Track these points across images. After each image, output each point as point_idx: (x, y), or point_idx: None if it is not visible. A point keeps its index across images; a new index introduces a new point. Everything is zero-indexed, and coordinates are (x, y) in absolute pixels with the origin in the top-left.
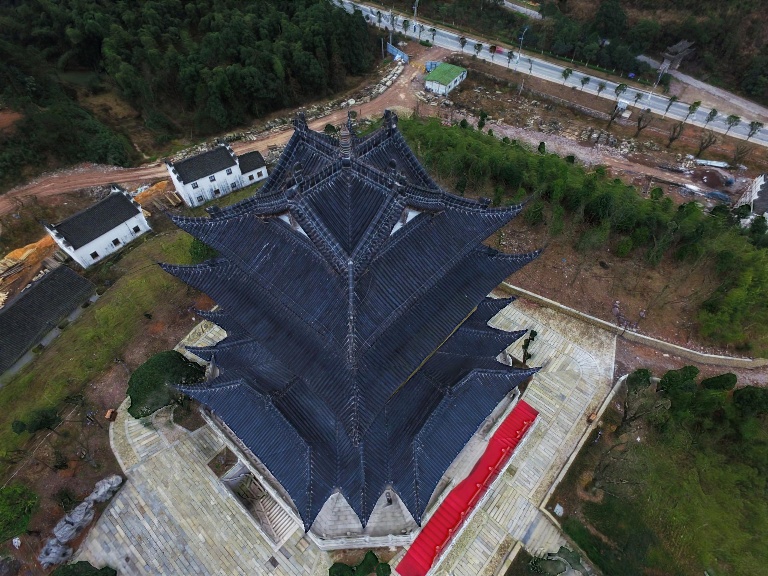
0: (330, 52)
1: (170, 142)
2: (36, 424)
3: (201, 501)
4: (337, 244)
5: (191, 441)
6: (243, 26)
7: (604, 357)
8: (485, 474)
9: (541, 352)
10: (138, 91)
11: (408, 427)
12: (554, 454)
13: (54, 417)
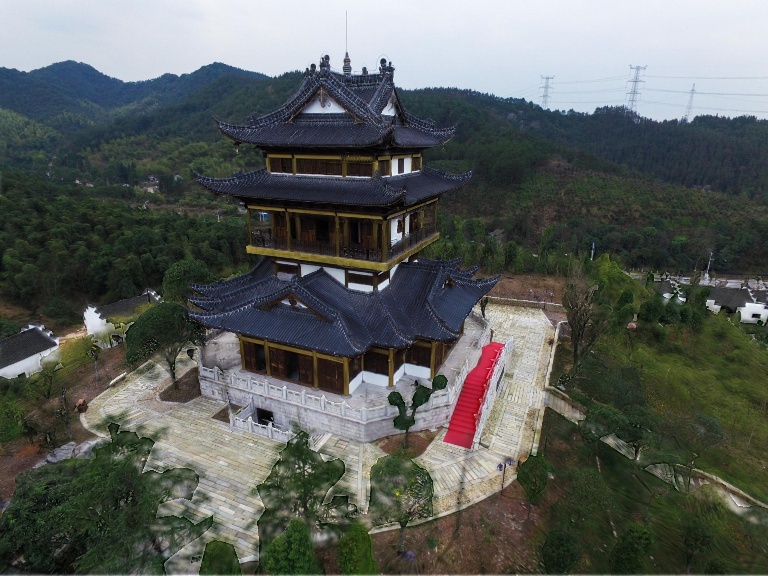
0: (233, 251)
1: (71, 327)
2: (7, 382)
3: (213, 440)
4: (358, 97)
5: (187, 408)
6: (154, 233)
7: (539, 318)
8: (490, 363)
9: (492, 320)
10: (40, 286)
11: (418, 301)
12: (536, 363)
13: (25, 383)
